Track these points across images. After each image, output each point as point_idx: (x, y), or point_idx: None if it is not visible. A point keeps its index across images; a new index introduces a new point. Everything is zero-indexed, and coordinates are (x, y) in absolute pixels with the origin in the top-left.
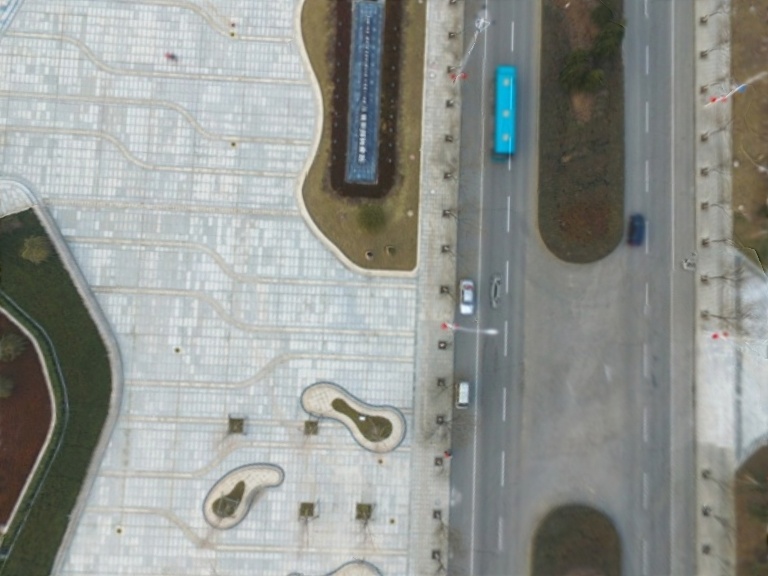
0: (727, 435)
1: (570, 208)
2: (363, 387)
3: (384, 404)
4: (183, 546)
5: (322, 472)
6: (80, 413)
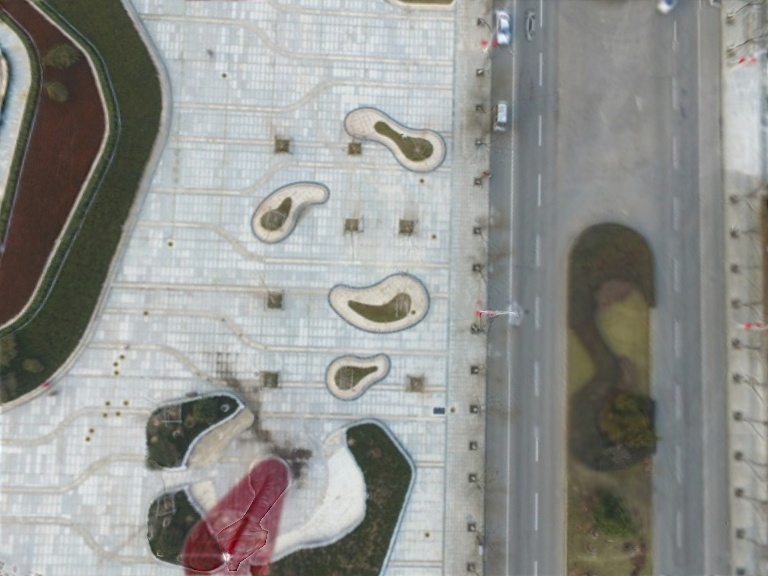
0: (753, 163)
1: None
2: (404, 112)
3: (425, 128)
4: (233, 259)
5: (366, 190)
6: (132, 128)
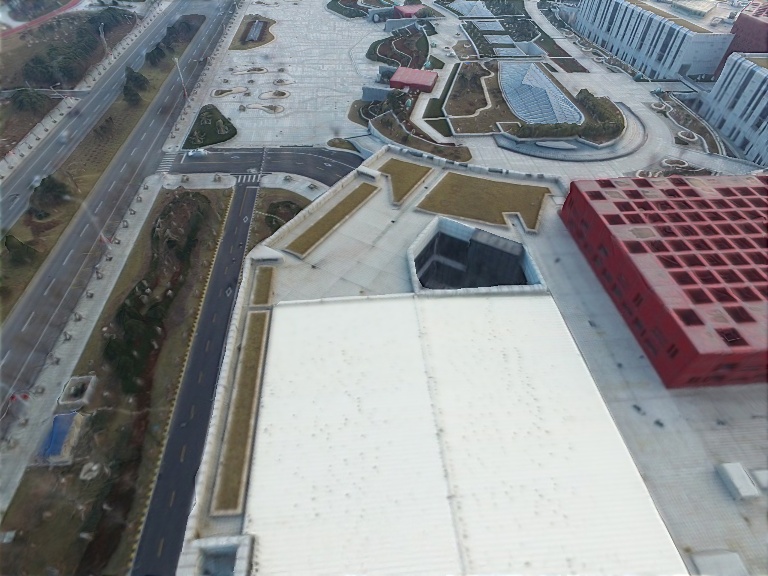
0: None
1: (195, 18)
2: None
3: None
4: None
5: None
6: None
